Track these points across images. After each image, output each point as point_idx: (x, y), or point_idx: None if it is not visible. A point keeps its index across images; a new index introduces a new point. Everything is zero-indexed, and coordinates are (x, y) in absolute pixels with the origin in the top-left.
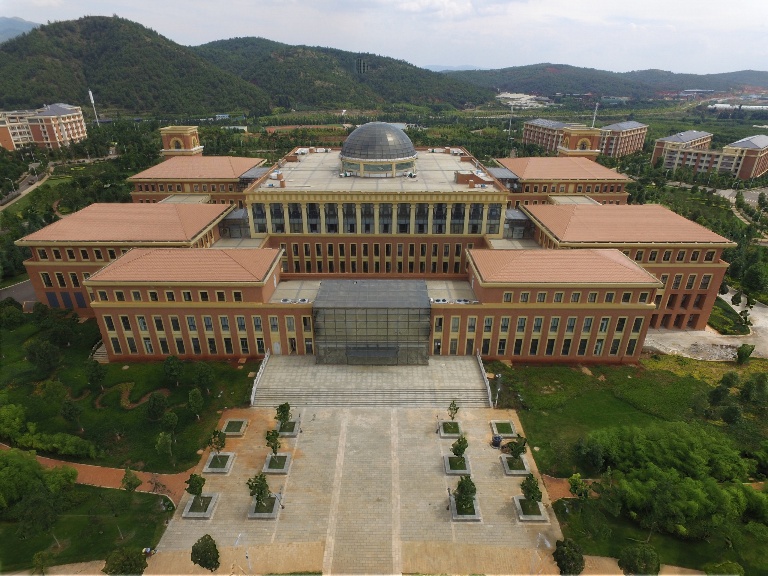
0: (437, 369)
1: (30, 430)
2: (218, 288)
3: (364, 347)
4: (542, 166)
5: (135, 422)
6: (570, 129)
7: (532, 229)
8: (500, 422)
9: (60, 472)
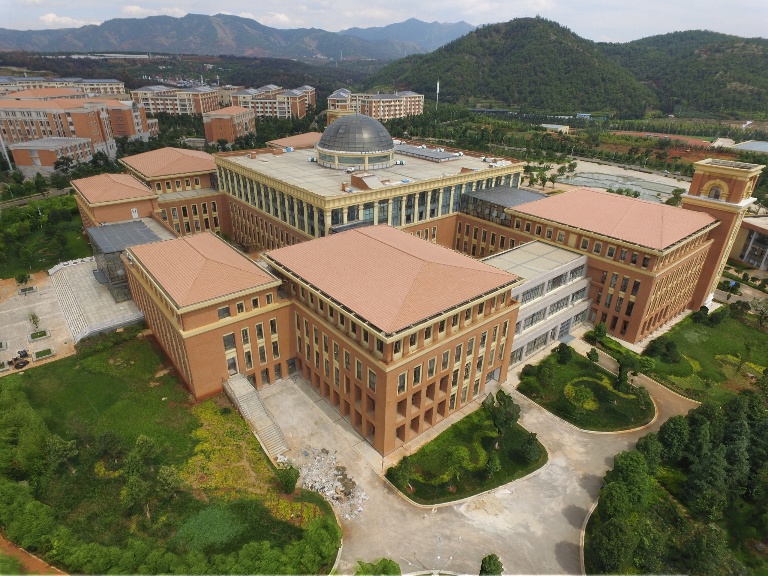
0: (113, 308)
1: None
2: None
3: None
4: (569, 201)
5: None
6: None
7: None
8: (51, 350)
9: None
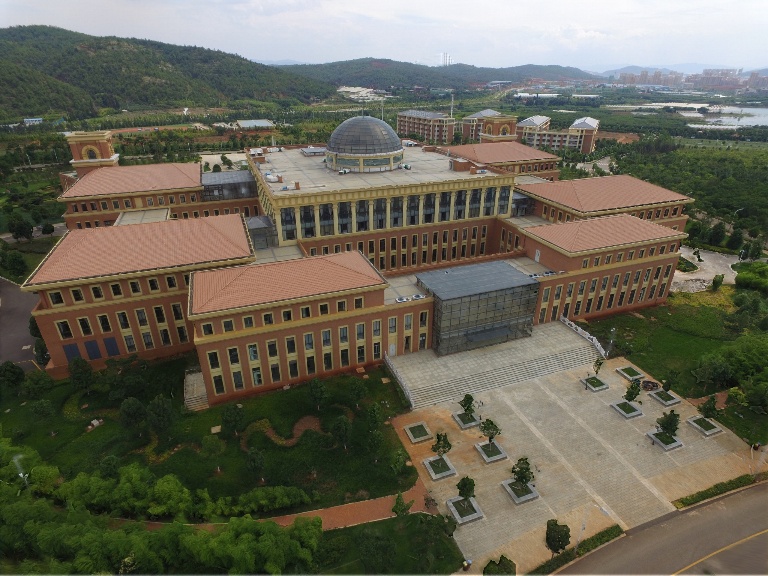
0: (541, 338)
1: (206, 498)
2: (341, 297)
3: (481, 330)
4: (487, 151)
5: (314, 456)
6: (493, 117)
7: (532, 206)
8: (624, 368)
9: (304, 525)
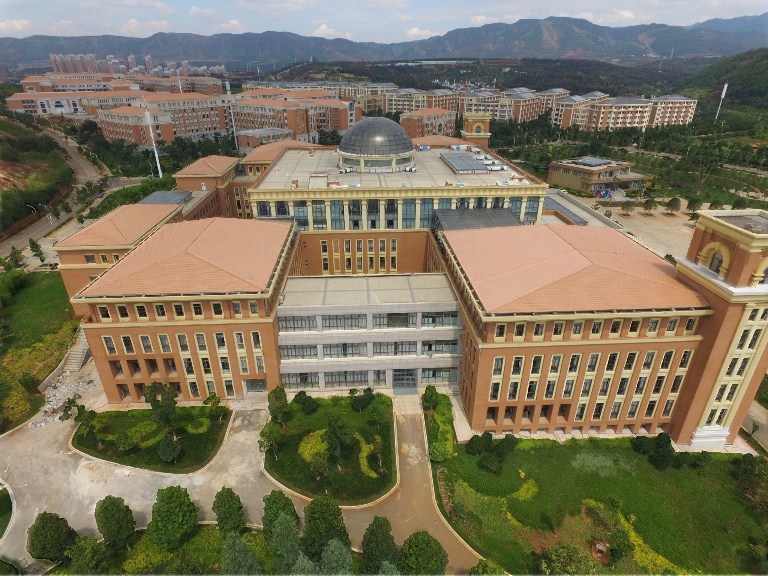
0: None
1: None
2: None
3: None
4: (505, 236)
5: None
6: None
7: None
8: None
9: None
